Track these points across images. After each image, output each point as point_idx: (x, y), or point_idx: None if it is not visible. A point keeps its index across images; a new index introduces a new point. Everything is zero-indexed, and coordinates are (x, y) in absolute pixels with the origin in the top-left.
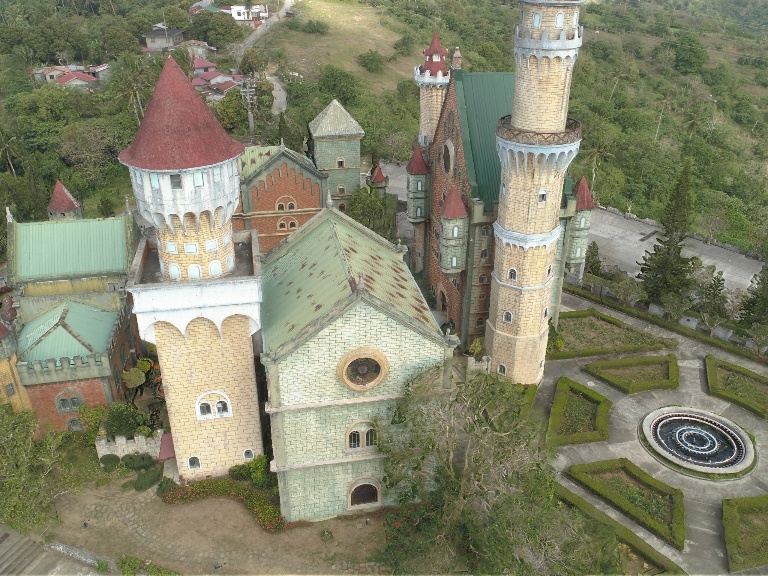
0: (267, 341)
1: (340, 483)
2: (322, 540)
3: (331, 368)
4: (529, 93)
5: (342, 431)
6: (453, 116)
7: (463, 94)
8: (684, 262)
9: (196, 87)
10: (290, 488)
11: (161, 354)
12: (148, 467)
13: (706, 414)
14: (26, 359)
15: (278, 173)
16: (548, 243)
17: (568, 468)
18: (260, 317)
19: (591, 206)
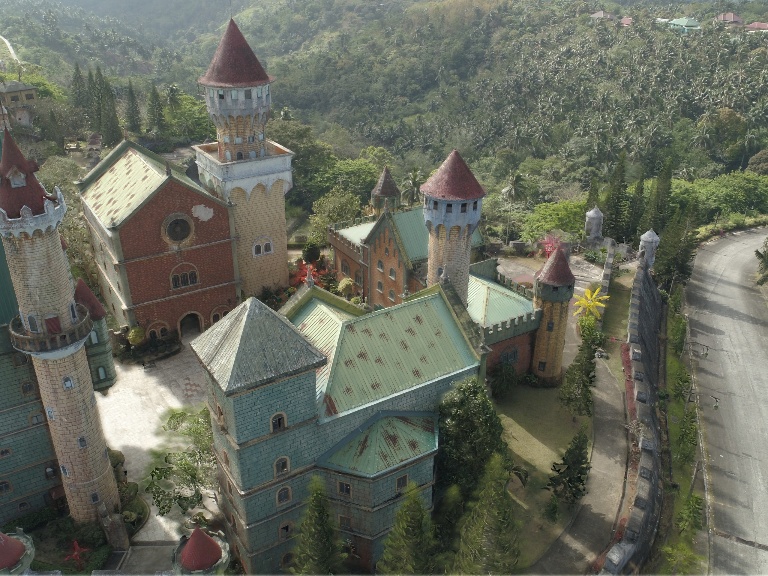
0: None
1: None
2: None
3: None
4: None
5: None
6: None
7: None
8: None
9: None
10: None
11: None
12: None
13: None
14: None
15: None
16: None
17: None
18: None
19: None
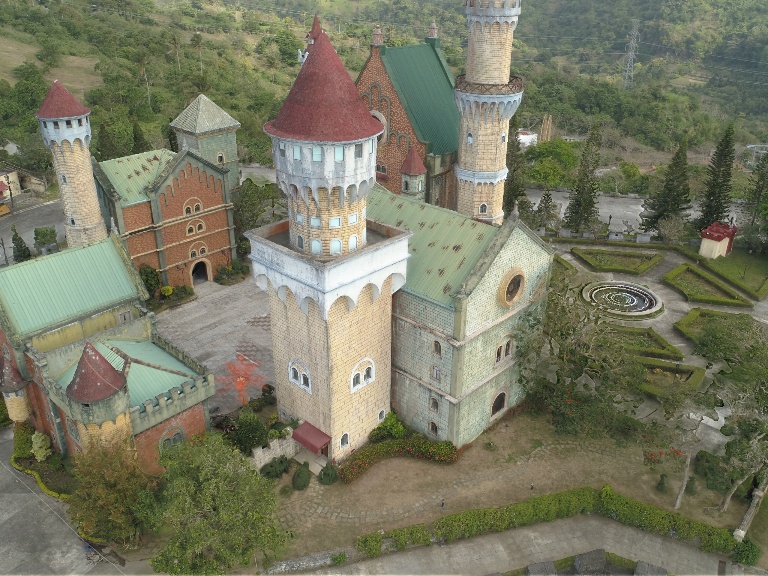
0: (420, 291)
1: (488, 399)
2: (491, 451)
3: (495, 292)
4: (493, 53)
5: (494, 349)
6: (380, 88)
7: (390, 67)
8: None
9: None
10: (461, 416)
11: (330, 334)
12: (288, 469)
13: (611, 282)
14: None
15: (183, 175)
16: None
17: None
18: None
19: None
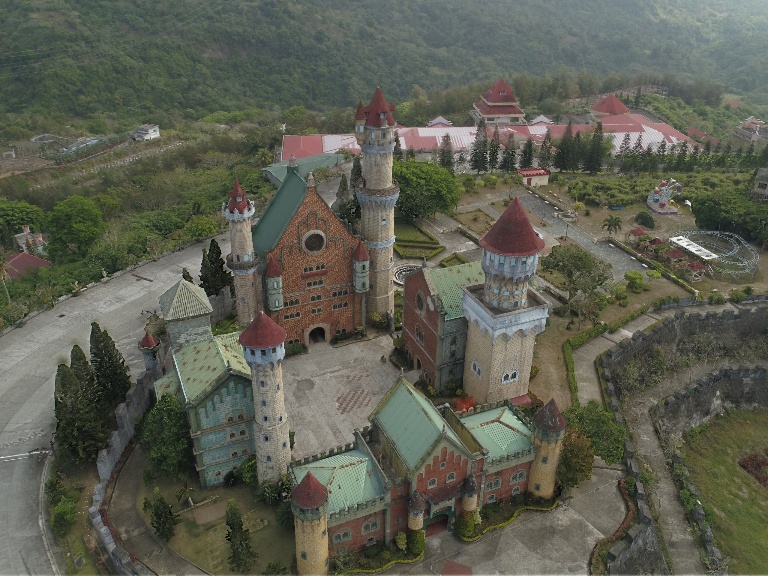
0: None
1: None
2: None
3: None
4: None
5: None
6: None
7: None
8: None
9: None
10: None
11: None
12: None
13: None
14: None
15: None
16: None
17: None
18: None
19: None
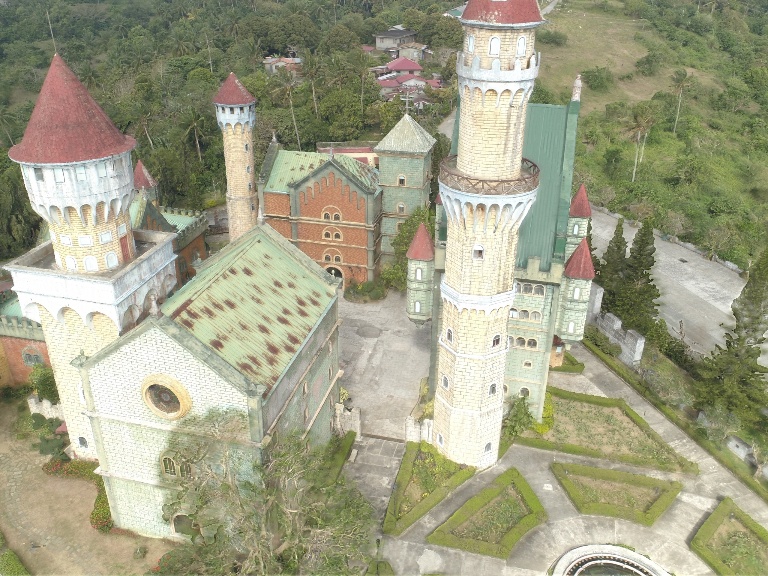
0: None
1: None
2: None
3: (136, 387)
4: (465, 129)
5: (156, 454)
6: None
7: None
8: (759, 371)
9: (388, 88)
10: (116, 494)
11: (46, 333)
12: (63, 434)
13: (658, 572)
14: (4, 312)
15: (325, 182)
16: (487, 308)
17: (427, 575)
18: (119, 319)
19: (588, 275)
